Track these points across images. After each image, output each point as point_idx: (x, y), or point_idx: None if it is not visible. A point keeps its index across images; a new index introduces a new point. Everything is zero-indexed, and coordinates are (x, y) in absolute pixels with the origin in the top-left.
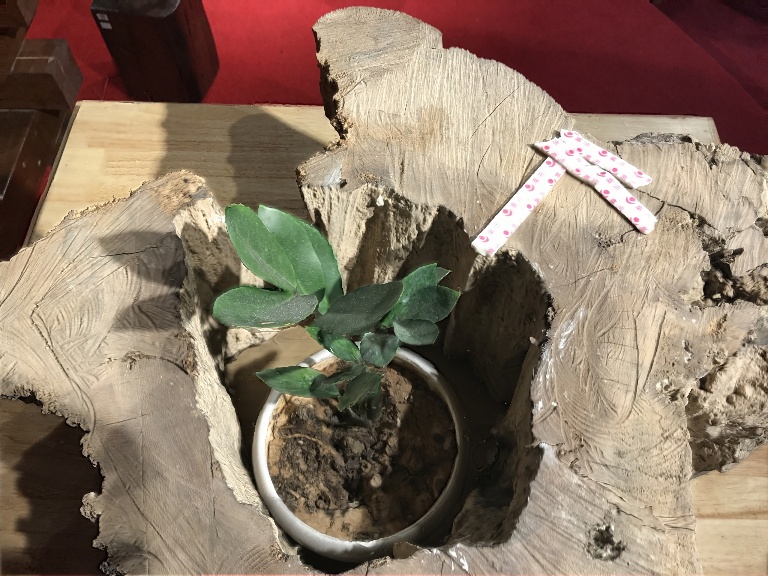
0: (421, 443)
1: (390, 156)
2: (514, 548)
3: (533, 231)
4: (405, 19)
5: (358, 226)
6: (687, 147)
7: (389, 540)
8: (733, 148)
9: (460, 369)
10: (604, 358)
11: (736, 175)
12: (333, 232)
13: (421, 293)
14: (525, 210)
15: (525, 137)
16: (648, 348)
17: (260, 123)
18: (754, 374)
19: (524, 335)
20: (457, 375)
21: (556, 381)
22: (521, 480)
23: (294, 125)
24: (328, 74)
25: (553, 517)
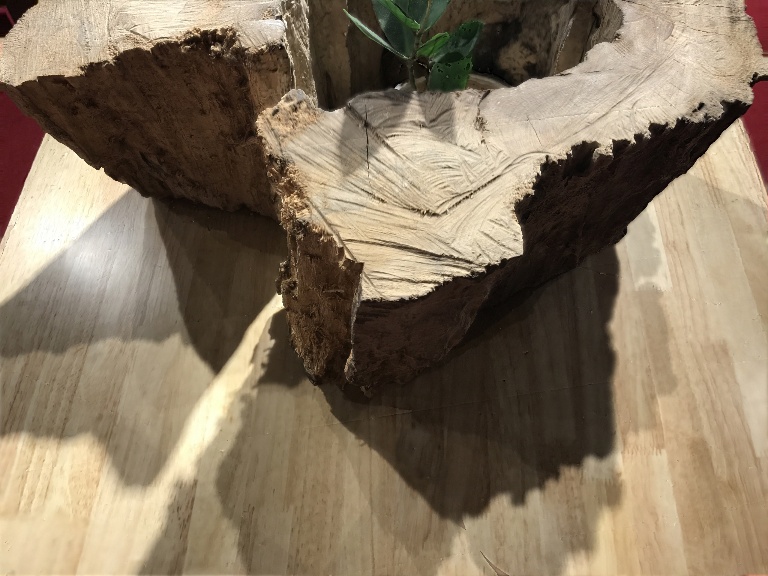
0: None
1: (241, 4)
2: None
3: None
4: (37, 7)
5: None
6: None
7: None
8: None
9: None
10: None
11: None
12: None
13: None
14: None
15: None
16: None
17: (6, 322)
18: None
19: None
20: None
21: None
22: None
23: (23, 283)
24: (104, 64)
25: None
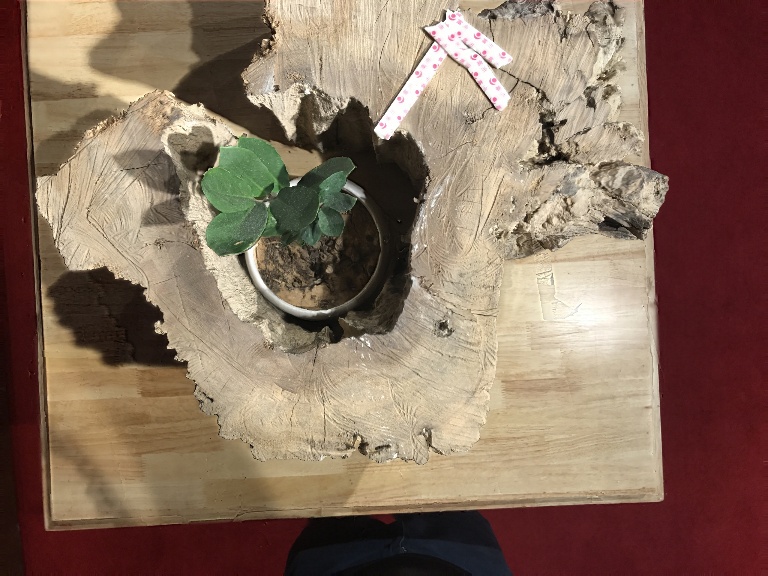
0: (358, 242)
1: (311, 53)
2: (395, 334)
3: (419, 114)
4: None
5: (295, 101)
6: (547, 20)
7: (339, 309)
8: (583, 18)
9: (390, 171)
10: (459, 212)
11: (578, 48)
12: (276, 110)
13: (334, 194)
14: (414, 96)
15: (418, 19)
16: (488, 203)
17: None
18: (559, 211)
19: (423, 172)
20: (388, 176)
21: (428, 230)
22: None
23: None
24: None
25: (416, 318)
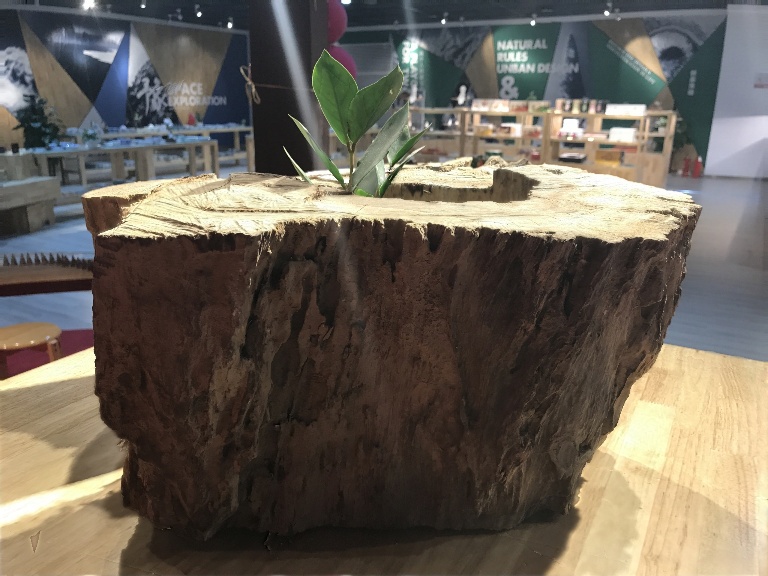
0: None
1: None
2: None
3: None
4: None
5: None
6: None
7: None
8: None
9: None
10: None
11: None
12: None
13: None
14: (345, 179)
15: None
16: None
17: None
18: None
19: None
20: None
21: None
22: (504, 198)
23: (20, 386)
24: (144, 195)
25: (534, 172)
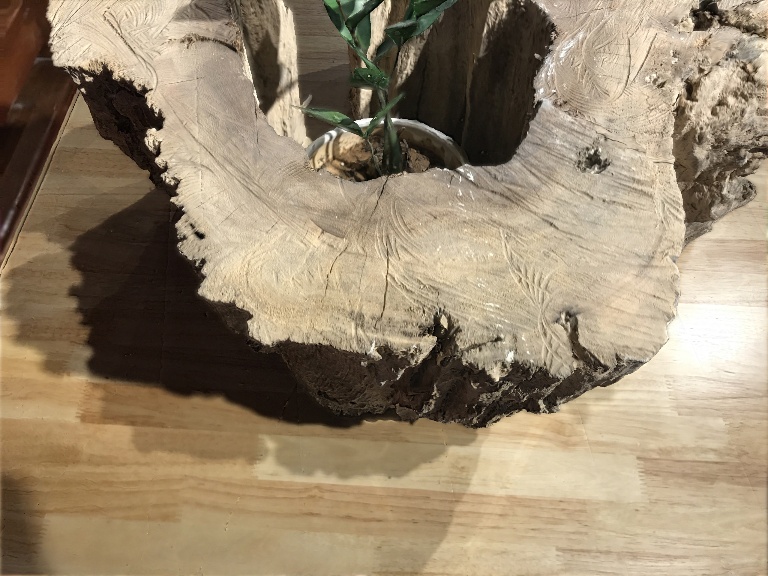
0: None
1: None
2: (514, 166)
3: None
4: None
5: (384, 3)
6: None
7: None
8: None
9: None
10: (600, 62)
11: None
12: None
13: None
14: None
15: None
16: (639, 56)
17: None
18: (736, 85)
19: None
20: None
21: (556, 77)
22: None
23: None
24: None
25: (548, 143)
